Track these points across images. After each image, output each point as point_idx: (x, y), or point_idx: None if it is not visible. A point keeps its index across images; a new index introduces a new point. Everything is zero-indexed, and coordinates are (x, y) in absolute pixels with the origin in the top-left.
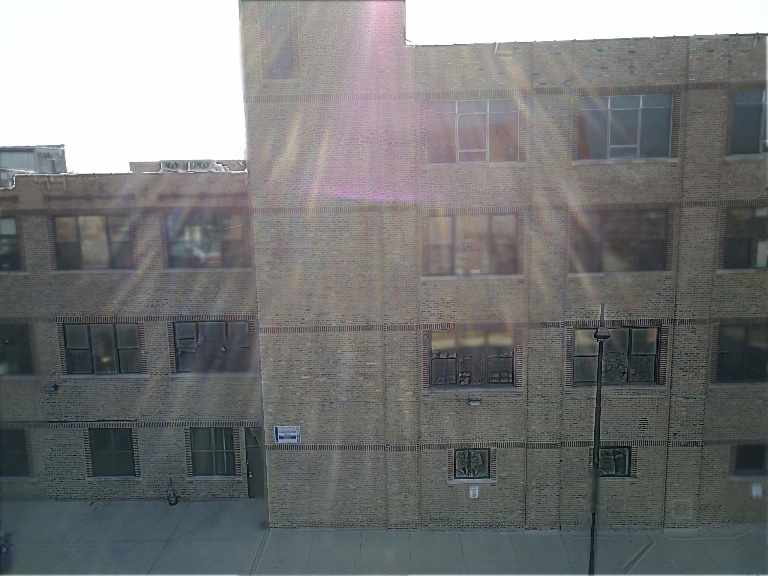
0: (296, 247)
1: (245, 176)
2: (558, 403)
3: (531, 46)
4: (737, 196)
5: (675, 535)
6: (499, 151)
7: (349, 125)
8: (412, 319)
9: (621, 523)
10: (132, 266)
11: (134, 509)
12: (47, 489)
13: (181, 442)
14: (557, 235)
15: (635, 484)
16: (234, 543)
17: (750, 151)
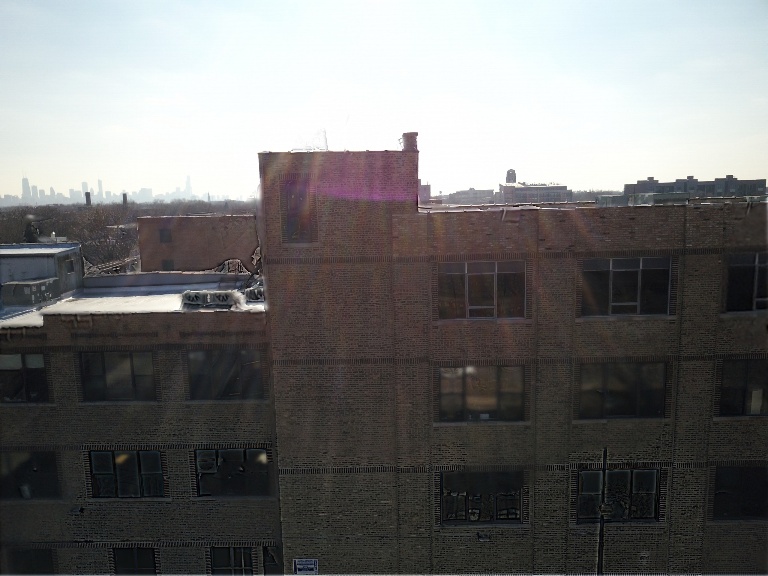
0: (314, 396)
1: (263, 315)
2: (563, 539)
3: (537, 214)
4: (732, 350)
5: None
6: (507, 309)
7: (365, 288)
8: (424, 462)
9: None
10: (155, 398)
11: None
12: None
13: (202, 560)
14: (562, 386)
15: None
16: None
17: (744, 308)
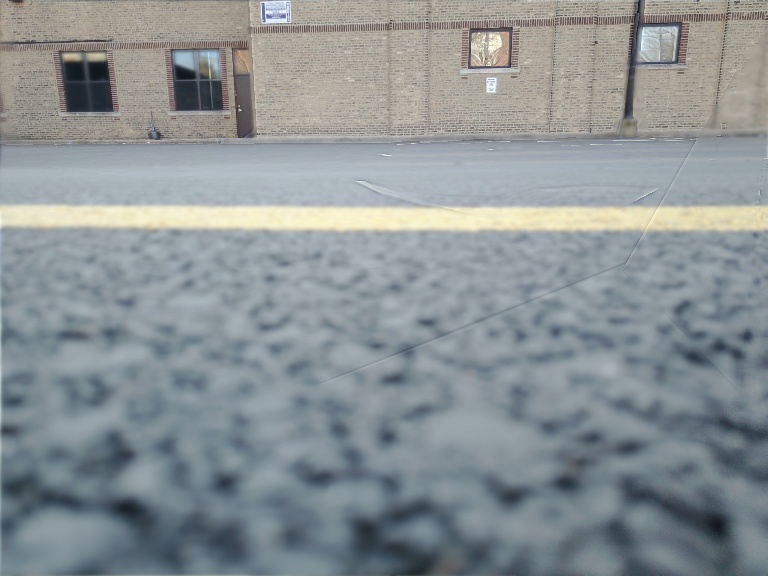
0: None
1: None
2: None
3: None
4: None
5: None
6: None
7: None
8: None
9: (663, 125)
10: None
11: None
12: (18, 127)
13: (162, 68)
14: None
15: (683, 73)
16: None
17: None
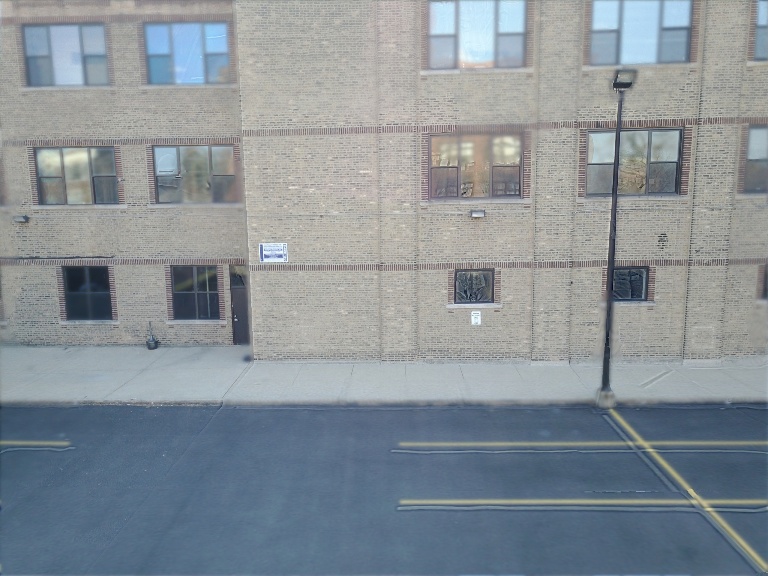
0: (283, 37)
1: None
2: (569, 216)
3: None
4: None
5: (696, 366)
6: None
7: None
8: (410, 119)
9: (636, 354)
10: (108, 82)
11: (110, 352)
12: (18, 334)
13: (161, 281)
14: (570, 20)
15: (652, 310)
16: (215, 370)
17: None
